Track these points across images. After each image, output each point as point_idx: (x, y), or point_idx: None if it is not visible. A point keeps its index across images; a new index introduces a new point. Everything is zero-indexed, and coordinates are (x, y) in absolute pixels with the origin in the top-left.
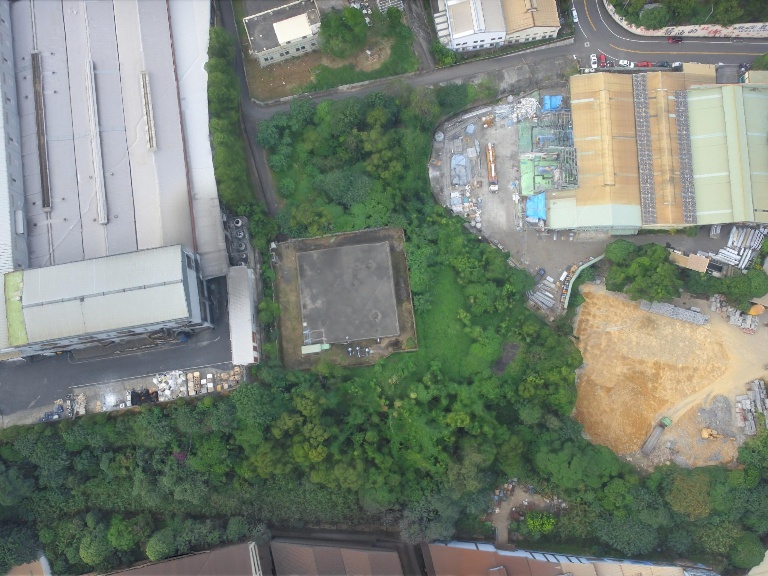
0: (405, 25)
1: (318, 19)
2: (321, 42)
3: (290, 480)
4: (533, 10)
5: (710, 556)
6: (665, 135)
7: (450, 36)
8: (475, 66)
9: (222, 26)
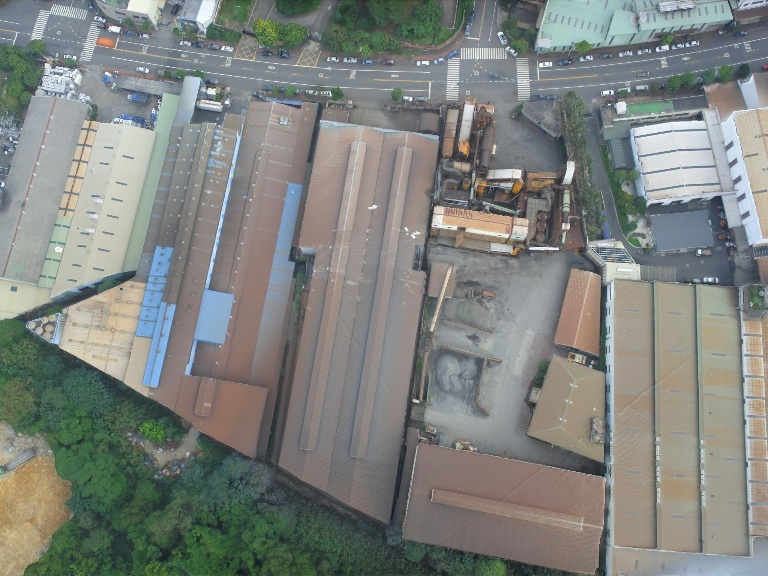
0: None
1: None
2: None
3: (348, 575)
4: None
5: (41, 340)
6: None
7: None
8: None
9: None
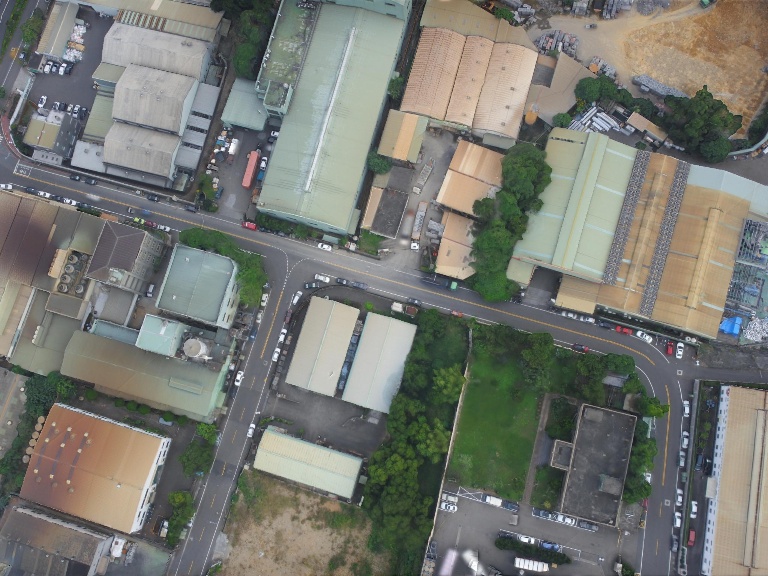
0: None
1: None
2: None
3: None
4: None
5: None
6: (644, 241)
7: None
8: None
9: None
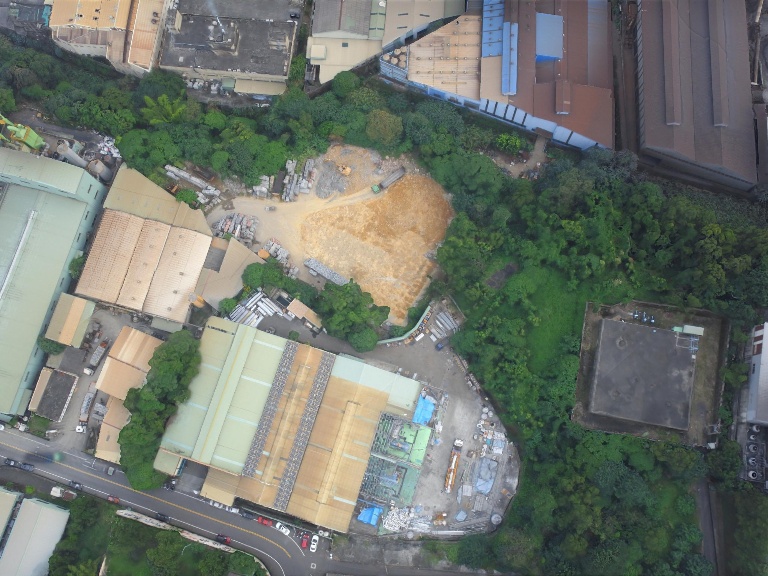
0: None
1: None
2: None
3: None
4: None
5: (375, 89)
6: (282, 434)
7: None
8: None
9: None
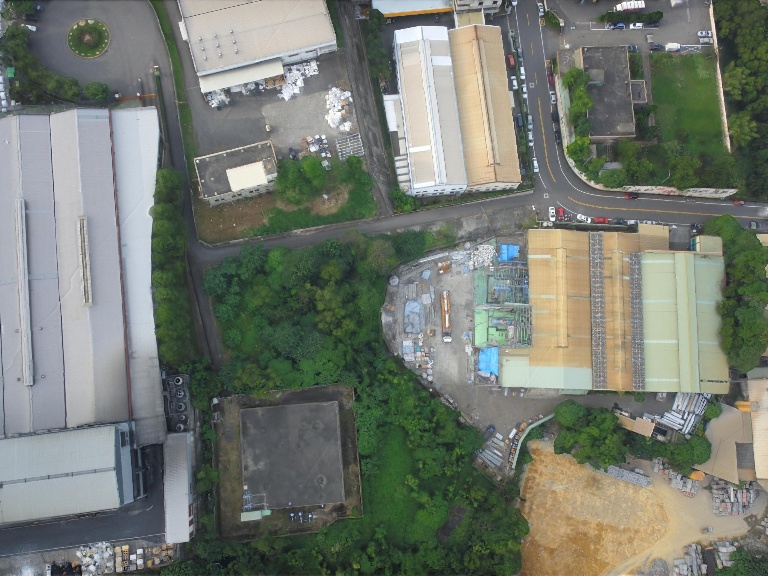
0: (365, 171)
1: (275, 169)
2: (277, 191)
3: None
4: (495, 165)
5: None
6: (619, 298)
7: (410, 183)
8: (434, 213)
9: (170, 160)
